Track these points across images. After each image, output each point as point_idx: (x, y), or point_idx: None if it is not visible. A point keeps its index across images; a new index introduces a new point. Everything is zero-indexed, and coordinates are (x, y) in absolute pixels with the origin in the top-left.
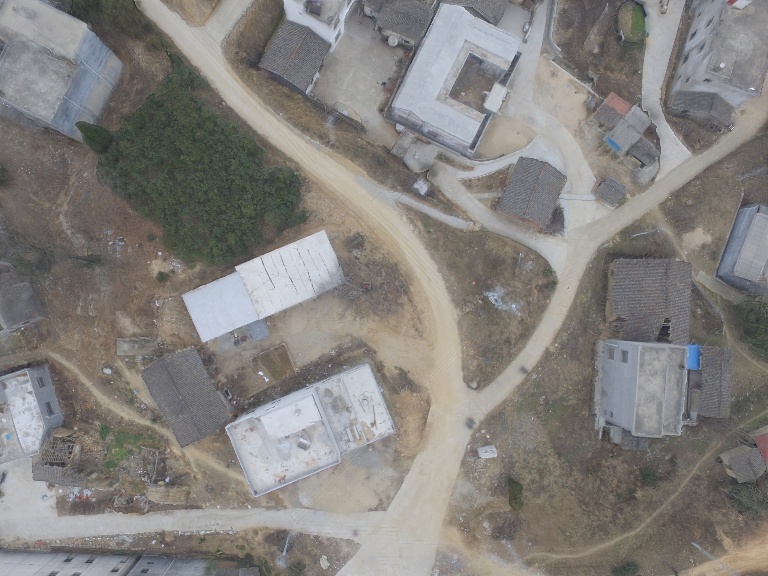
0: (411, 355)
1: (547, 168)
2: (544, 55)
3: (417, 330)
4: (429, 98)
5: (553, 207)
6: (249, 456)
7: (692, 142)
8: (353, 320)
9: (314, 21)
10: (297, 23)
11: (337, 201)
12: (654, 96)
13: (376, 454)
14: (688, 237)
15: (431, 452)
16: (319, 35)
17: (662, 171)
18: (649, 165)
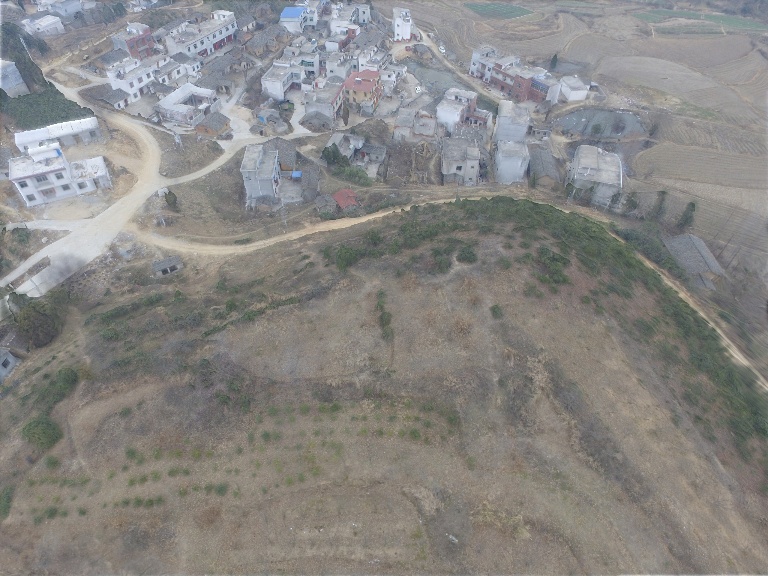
0: (132, 164)
1: (218, 113)
2: (236, 105)
3: (137, 155)
4: (169, 103)
5: (222, 127)
6: (16, 170)
7: (310, 127)
8: (103, 151)
9: (120, 81)
10: (116, 89)
11: (113, 124)
12: (296, 121)
13: (98, 198)
14: (304, 147)
15: (131, 196)
16: (125, 91)
17: (293, 133)
18: (277, 122)
